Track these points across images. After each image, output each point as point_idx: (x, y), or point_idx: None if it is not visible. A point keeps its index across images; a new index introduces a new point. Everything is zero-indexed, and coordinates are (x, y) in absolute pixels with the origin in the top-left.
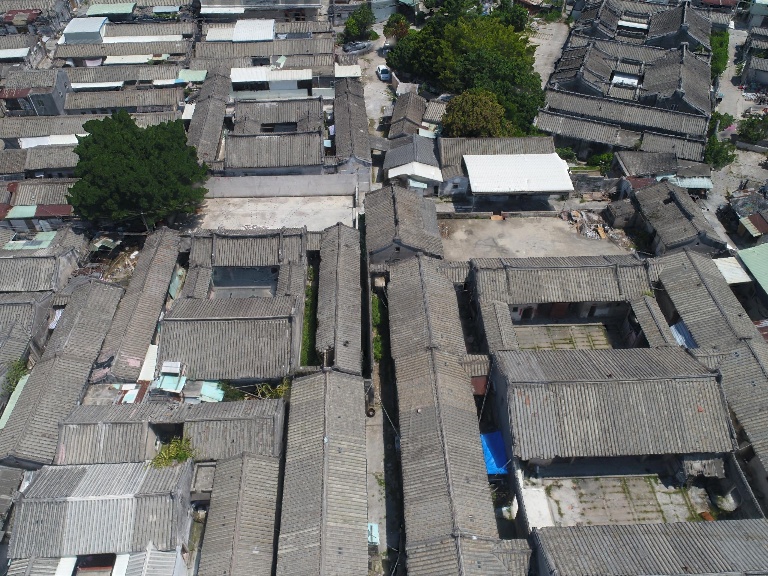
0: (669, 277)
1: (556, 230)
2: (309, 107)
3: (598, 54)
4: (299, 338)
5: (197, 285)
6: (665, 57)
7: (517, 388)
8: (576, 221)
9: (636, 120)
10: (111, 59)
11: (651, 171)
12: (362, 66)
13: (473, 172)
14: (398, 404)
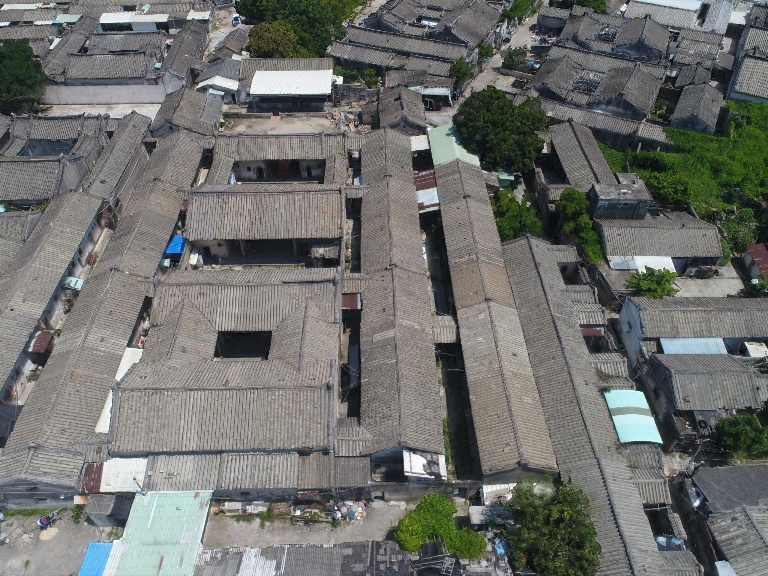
0: (367, 146)
1: (318, 126)
2: (150, 39)
3: (410, 3)
4: (77, 183)
5: (10, 149)
6: (462, 4)
7: (196, 196)
8: (335, 119)
9: (414, 49)
10: (7, 6)
11: (404, 83)
12: (222, 15)
13: (256, 81)
14: (122, 214)
